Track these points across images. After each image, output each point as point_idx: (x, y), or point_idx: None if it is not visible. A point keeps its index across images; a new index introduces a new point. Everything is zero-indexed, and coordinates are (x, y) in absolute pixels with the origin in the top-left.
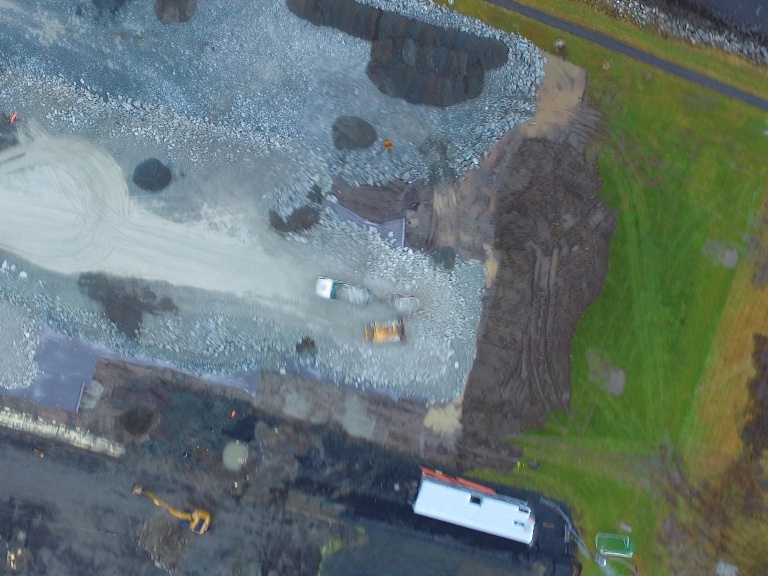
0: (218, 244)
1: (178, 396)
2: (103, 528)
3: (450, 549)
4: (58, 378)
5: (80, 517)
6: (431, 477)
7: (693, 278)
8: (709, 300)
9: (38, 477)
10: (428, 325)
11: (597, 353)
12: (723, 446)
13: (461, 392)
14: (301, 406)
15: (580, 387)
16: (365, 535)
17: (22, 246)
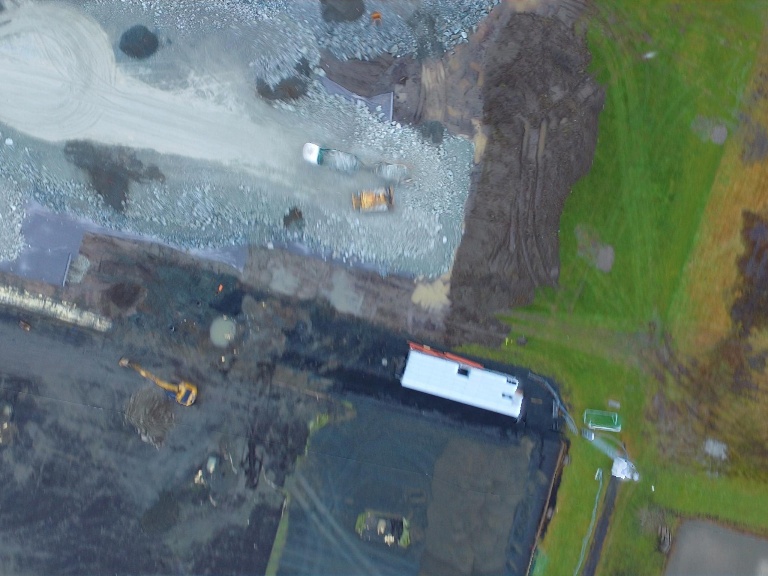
0: (205, 112)
1: (165, 270)
2: (89, 402)
3: (438, 424)
4: (44, 252)
5: (66, 391)
6: (419, 351)
7: (682, 154)
8: (698, 176)
9: (24, 350)
10: (416, 195)
11: (586, 229)
12: (712, 323)
13: (449, 268)
14: (289, 281)
15: (569, 263)
16: (353, 410)
17: (8, 113)
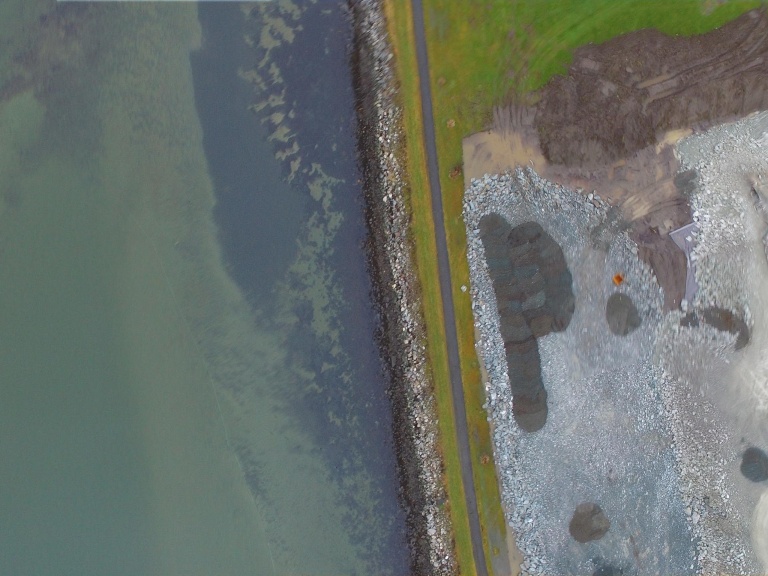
0: None
1: None
2: None
3: None
4: None
5: None
6: None
7: None
8: None
9: None
10: (766, 165)
11: (703, 6)
12: None
13: None
14: None
15: (739, 7)
16: None
17: None
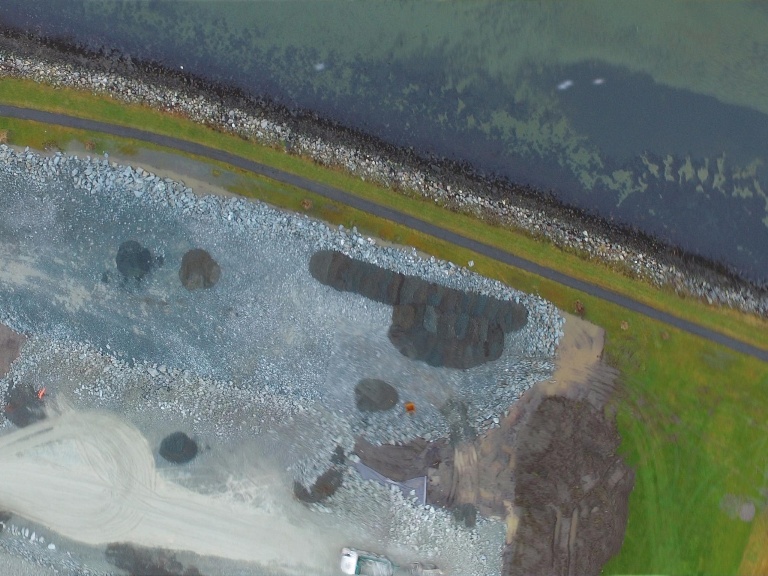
0: (243, 515)
1: None
2: None
3: None
4: None
5: None
6: None
7: (711, 532)
8: (727, 554)
9: None
10: None
11: None
12: None
13: None
14: None
15: None
16: None
17: (50, 518)
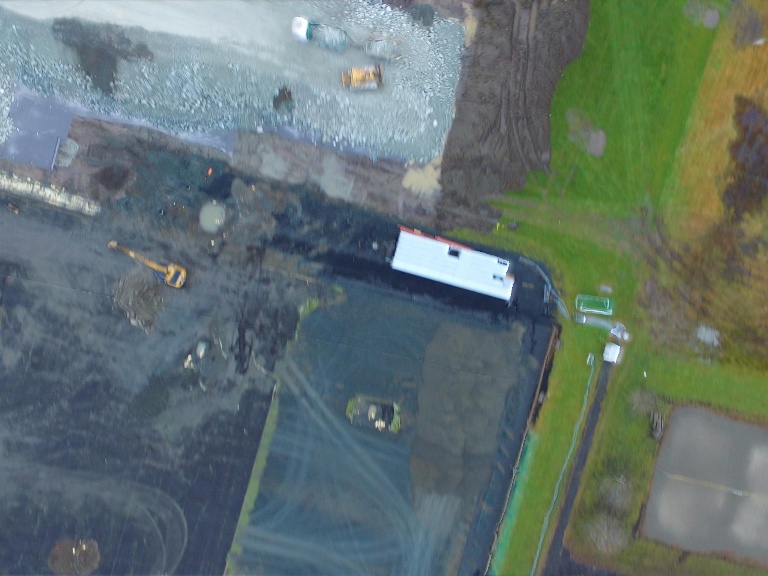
0: None
1: (154, 154)
2: (78, 286)
3: (429, 309)
4: (33, 135)
5: (55, 275)
6: None
7: (674, 38)
8: (690, 60)
9: (13, 234)
10: (406, 73)
11: (577, 113)
12: (704, 209)
13: (440, 152)
14: (279, 166)
15: (560, 147)
16: (343, 294)
17: None
